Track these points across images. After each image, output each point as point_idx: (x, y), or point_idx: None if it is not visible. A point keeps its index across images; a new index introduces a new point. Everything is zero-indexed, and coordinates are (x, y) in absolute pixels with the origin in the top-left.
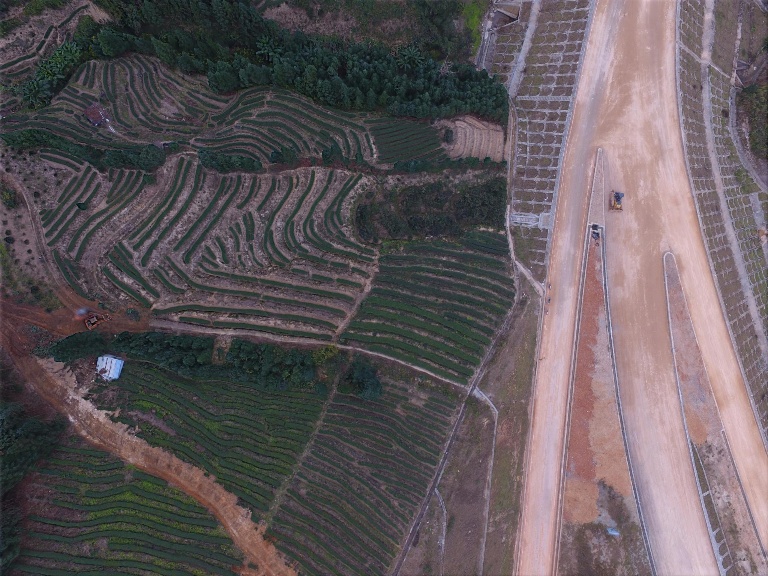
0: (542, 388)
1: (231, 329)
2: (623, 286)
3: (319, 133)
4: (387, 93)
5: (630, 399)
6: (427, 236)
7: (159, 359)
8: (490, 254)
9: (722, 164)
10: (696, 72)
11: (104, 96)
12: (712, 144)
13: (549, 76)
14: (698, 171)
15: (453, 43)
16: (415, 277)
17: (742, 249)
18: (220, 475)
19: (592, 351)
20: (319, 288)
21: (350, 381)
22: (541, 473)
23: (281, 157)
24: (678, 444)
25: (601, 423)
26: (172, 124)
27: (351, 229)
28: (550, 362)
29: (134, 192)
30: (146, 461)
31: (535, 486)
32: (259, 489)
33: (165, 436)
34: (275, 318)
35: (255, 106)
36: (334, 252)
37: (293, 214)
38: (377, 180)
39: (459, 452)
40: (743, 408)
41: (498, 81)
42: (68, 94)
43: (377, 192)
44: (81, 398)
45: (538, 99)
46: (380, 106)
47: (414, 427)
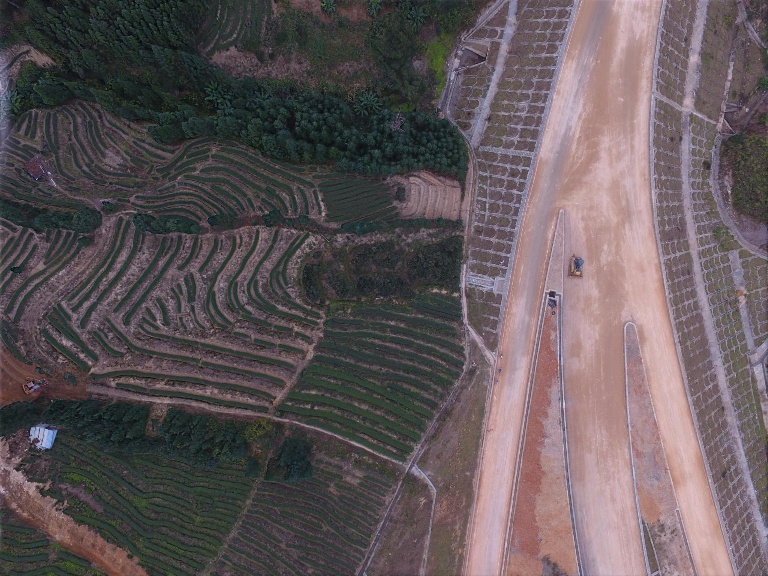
0: (489, 460)
1: (167, 397)
2: (579, 357)
3: (264, 190)
4: (338, 146)
5: (580, 475)
6: (377, 297)
7: (88, 433)
8: (441, 319)
9: (699, 222)
10: (675, 122)
11: (46, 147)
12: (689, 201)
13: (513, 127)
14: (669, 233)
15: (414, 87)
16: (360, 343)
17: (714, 314)
18: (143, 557)
19: (542, 424)
20: (260, 354)
21: (278, 464)
22: (484, 546)
23: (218, 222)
24: (628, 522)
25: (548, 499)
26: (116, 176)
27: (297, 290)
28: (498, 434)
29: (71, 253)
30: (72, 539)
31: (478, 559)
32: (181, 573)
33: (92, 513)
34: (212, 386)
35: (200, 160)
36: (278, 314)
37: (236, 275)
38: (325, 239)
39: (392, 534)
40: (701, 487)
41: (461, 128)
42: (9, 145)
43: (326, 251)
44: (13, 469)
45: (500, 152)
46: (331, 159)
47: (346, 507)
